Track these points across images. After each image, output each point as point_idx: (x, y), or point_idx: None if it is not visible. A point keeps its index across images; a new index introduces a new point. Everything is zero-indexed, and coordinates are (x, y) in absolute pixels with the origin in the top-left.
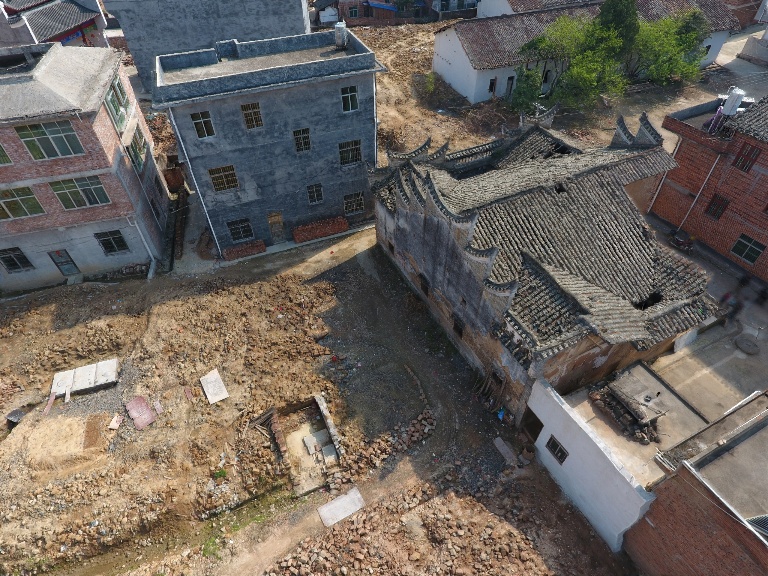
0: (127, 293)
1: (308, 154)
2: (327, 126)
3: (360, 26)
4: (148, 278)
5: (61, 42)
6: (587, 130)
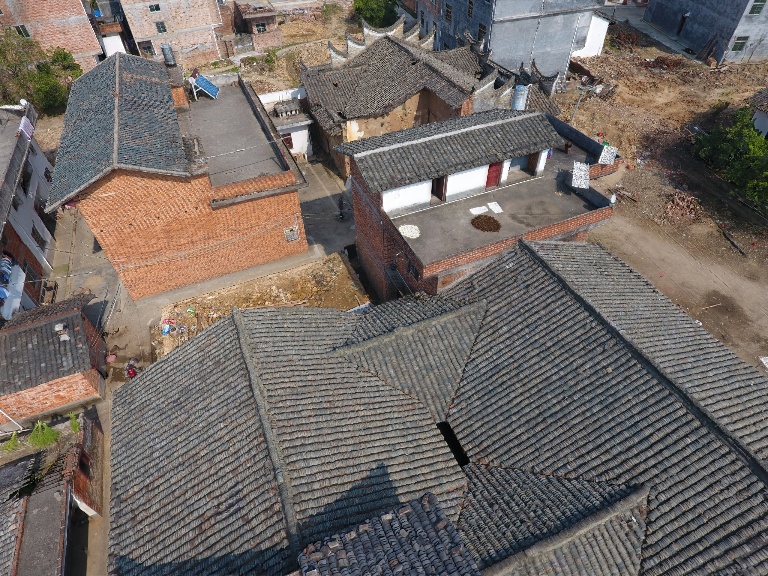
0: None
1: (470, 20)
2: (478, 6)
3: None
4: None
5: None
6: (706, 215)
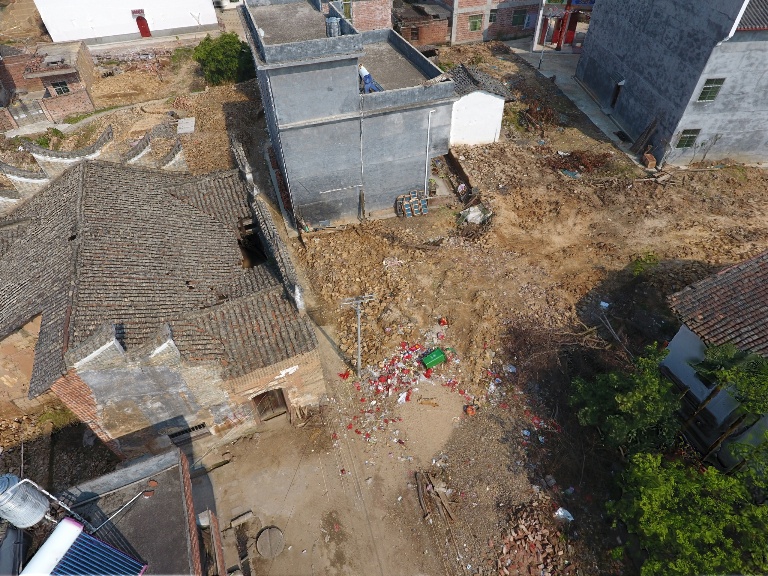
0: (247, 122)
1: None
2: None
3: None
4: (265, 128)
5: (583, 2)
6: None
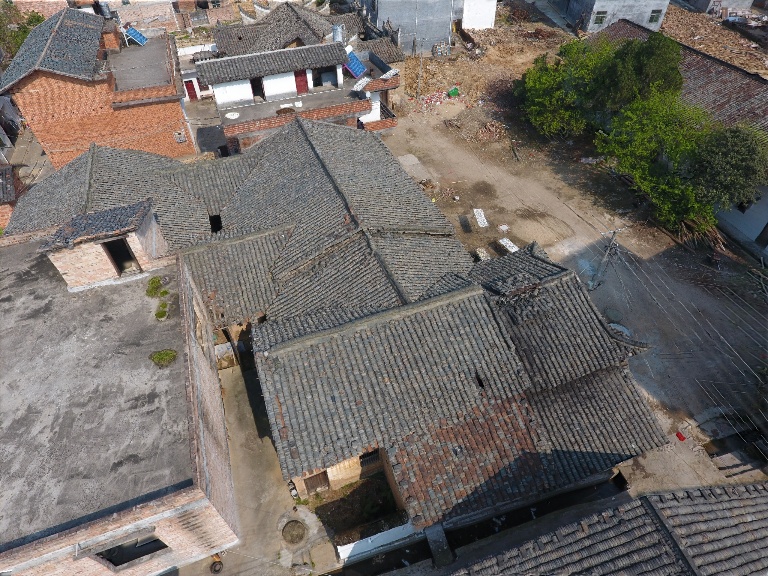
0: None
1: None
2: None
3: (756, 43)
4: None
5: None
6: (506, 136)
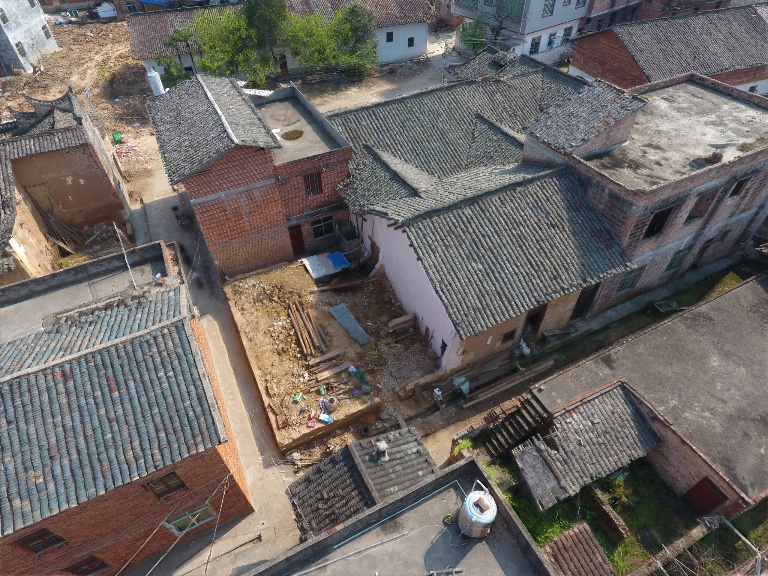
0: None
1: None
2: None
3: None
4: None
5: None
6: None
